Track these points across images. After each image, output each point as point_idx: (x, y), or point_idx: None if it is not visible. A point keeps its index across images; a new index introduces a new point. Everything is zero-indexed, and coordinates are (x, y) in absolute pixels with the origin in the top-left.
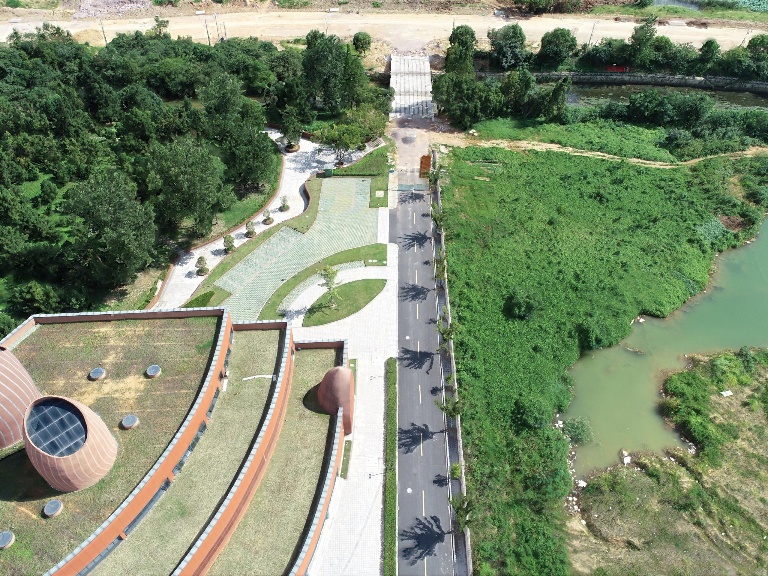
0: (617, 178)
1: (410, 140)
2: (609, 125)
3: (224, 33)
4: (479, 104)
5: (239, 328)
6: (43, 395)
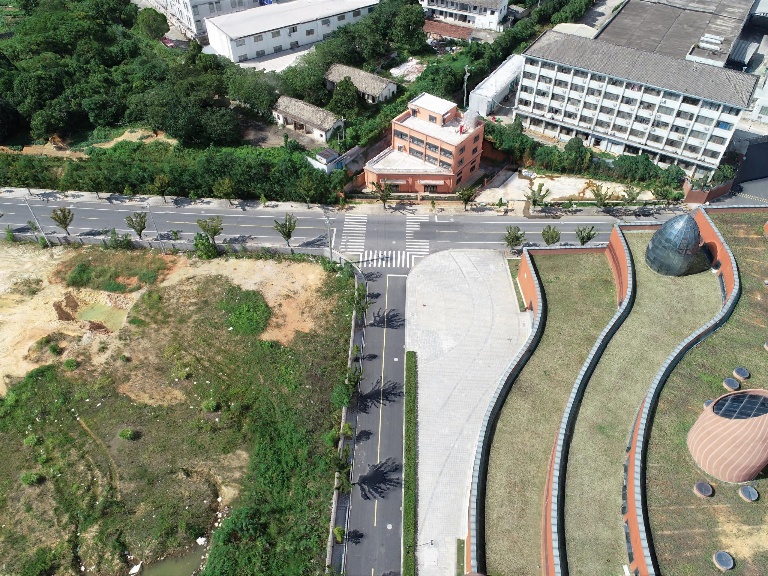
0: None
1: None
2: None
3: None
4: None
5: None
6: None
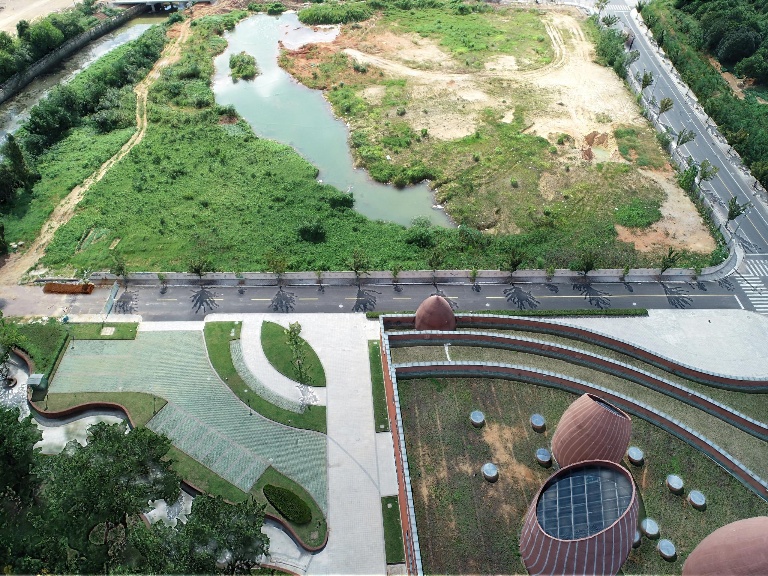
0: (154, 158)
1: None
2: (53, 153)
3: None
4: None
5: None
6: None
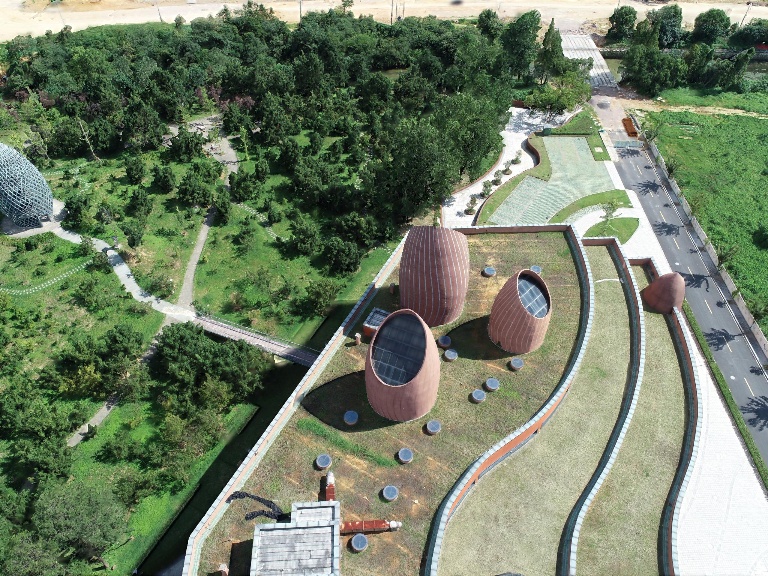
0: None
1: (606, 105)
2: None
3: (402, 12)
4: (669, 73)
5: None
6: None
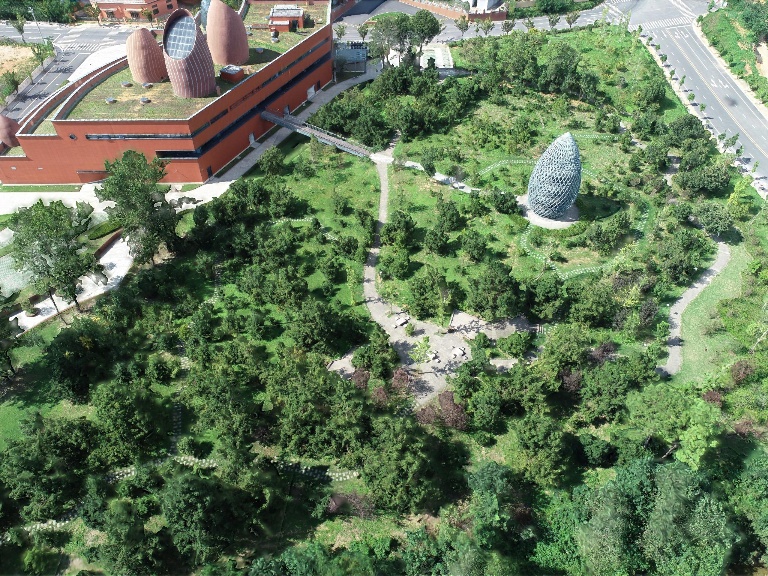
0: None
1: None
2: None
3: None
4: None
5: (56, 139)
6: (176, 95)
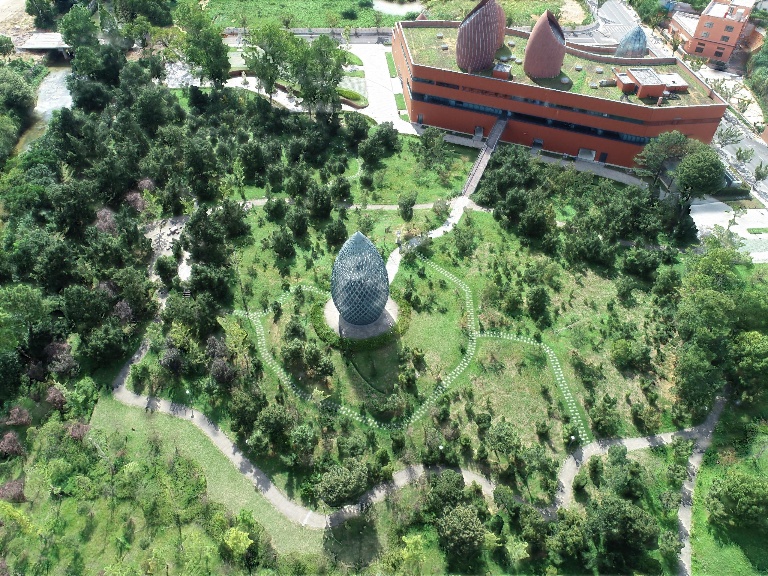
0: None
1: None
2: None
3: None
4: None
5: None
6: None
